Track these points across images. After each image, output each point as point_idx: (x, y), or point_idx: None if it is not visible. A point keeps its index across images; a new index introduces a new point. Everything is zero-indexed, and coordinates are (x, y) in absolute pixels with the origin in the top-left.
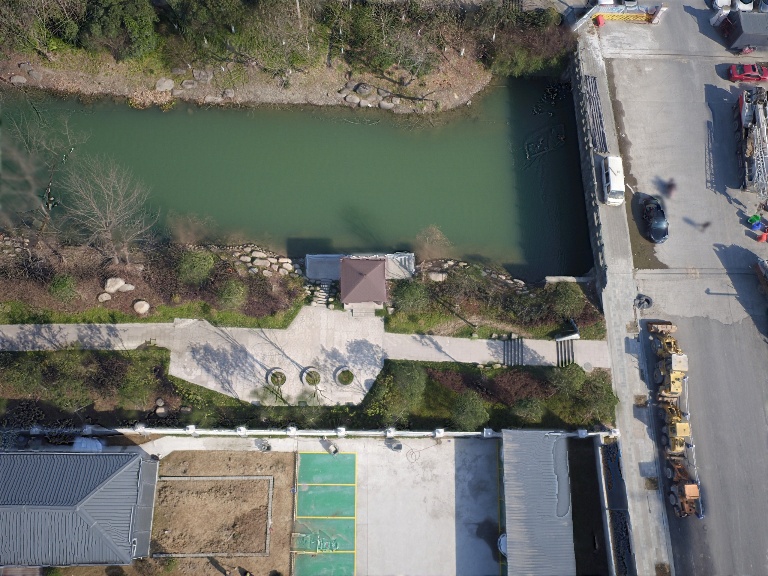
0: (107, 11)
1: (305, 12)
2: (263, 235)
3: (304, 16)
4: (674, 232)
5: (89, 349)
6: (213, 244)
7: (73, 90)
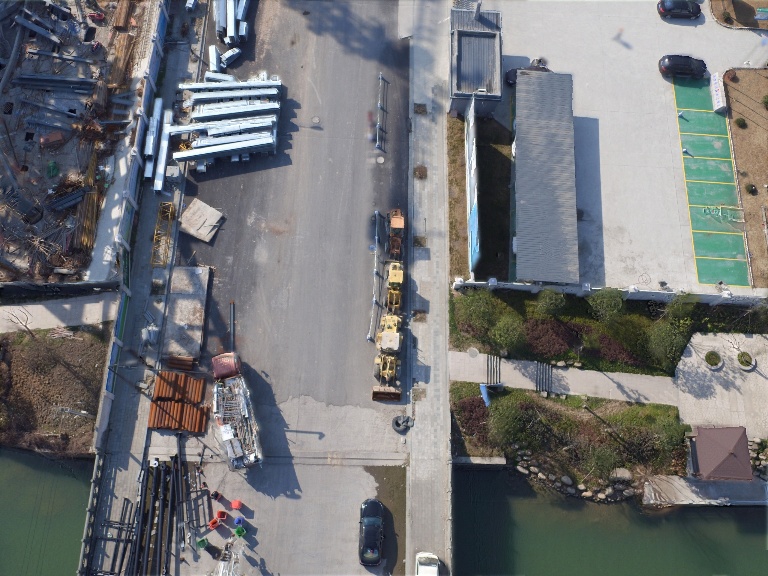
0: None
1: None
2: None
3: None
4: (348, 516)
5: None
6: None
7: None
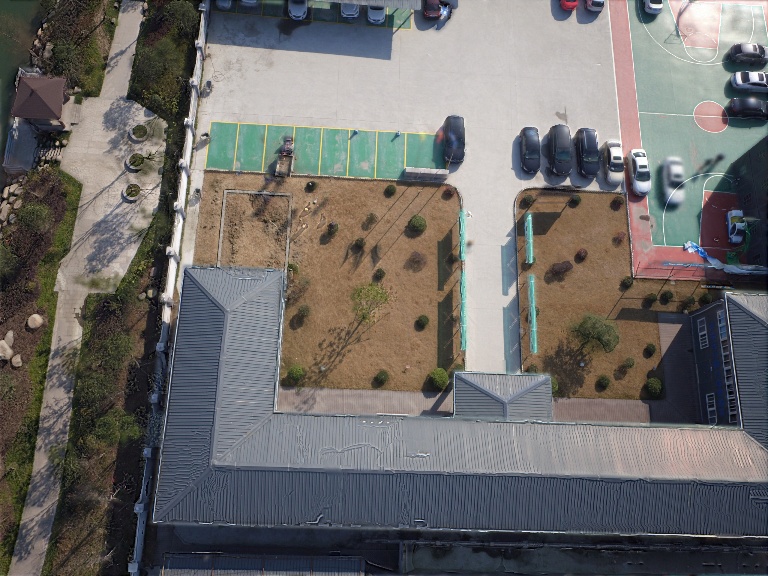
0: None
1: None
2: None
3: None
4: None
5: (75, 374)
6: None
7: None
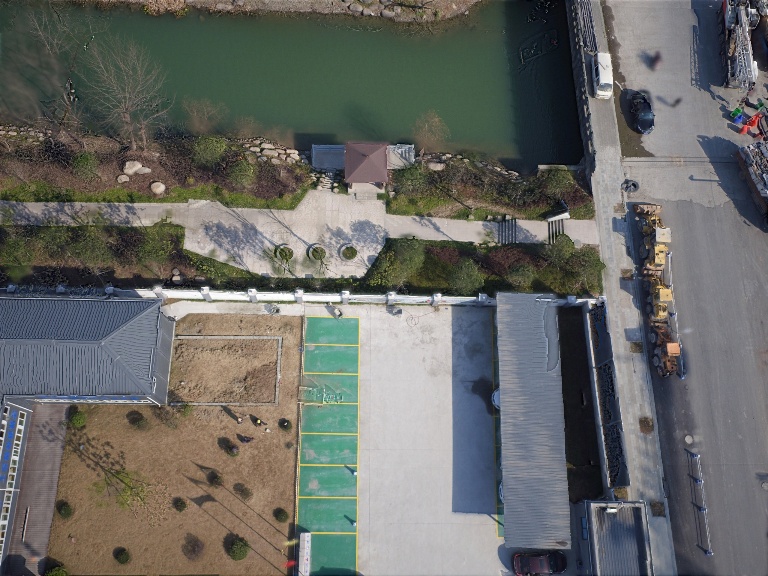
0: None
1: None
2: (271, 130)
3: None
4: (660, 124)
5: (109, 225)
6: (224, 137)
7: None
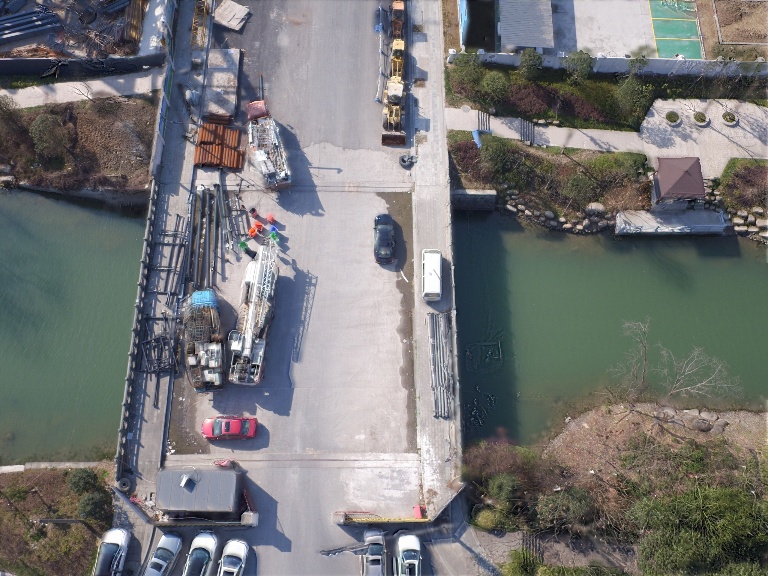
0: None
1: None
2: (765, 260)
3: None
4: (364, 229)
5: None
6: None
7: None
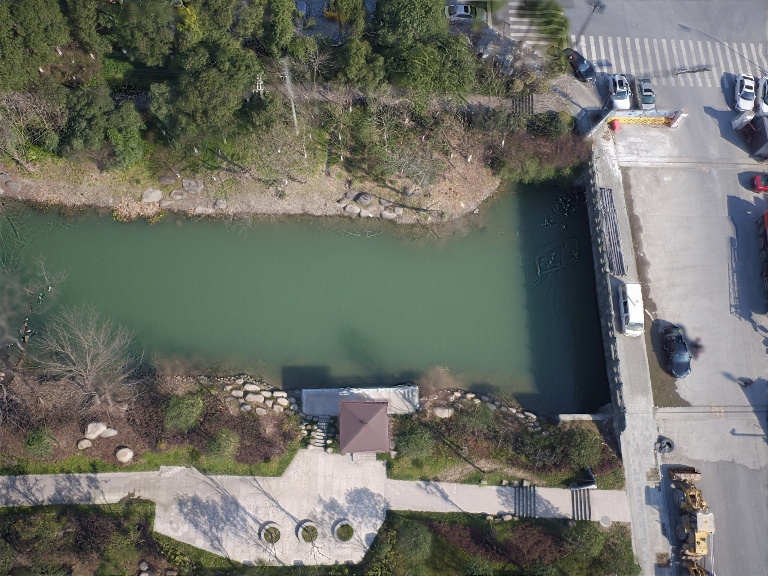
0: (90, 123)
1: (302, 121)
2: (256, 363)
3: (301, 124)
4: (696, 364)
5: (67, 503)
6: (203, 375)
7: (54, 201)
